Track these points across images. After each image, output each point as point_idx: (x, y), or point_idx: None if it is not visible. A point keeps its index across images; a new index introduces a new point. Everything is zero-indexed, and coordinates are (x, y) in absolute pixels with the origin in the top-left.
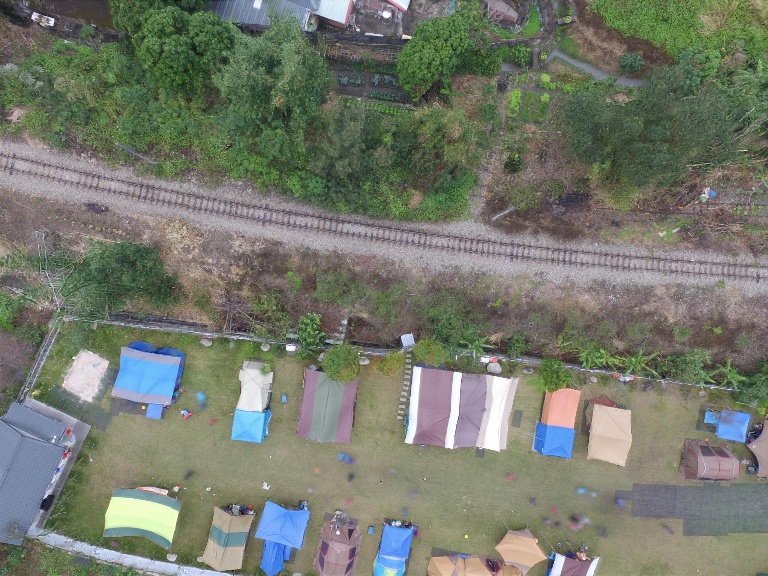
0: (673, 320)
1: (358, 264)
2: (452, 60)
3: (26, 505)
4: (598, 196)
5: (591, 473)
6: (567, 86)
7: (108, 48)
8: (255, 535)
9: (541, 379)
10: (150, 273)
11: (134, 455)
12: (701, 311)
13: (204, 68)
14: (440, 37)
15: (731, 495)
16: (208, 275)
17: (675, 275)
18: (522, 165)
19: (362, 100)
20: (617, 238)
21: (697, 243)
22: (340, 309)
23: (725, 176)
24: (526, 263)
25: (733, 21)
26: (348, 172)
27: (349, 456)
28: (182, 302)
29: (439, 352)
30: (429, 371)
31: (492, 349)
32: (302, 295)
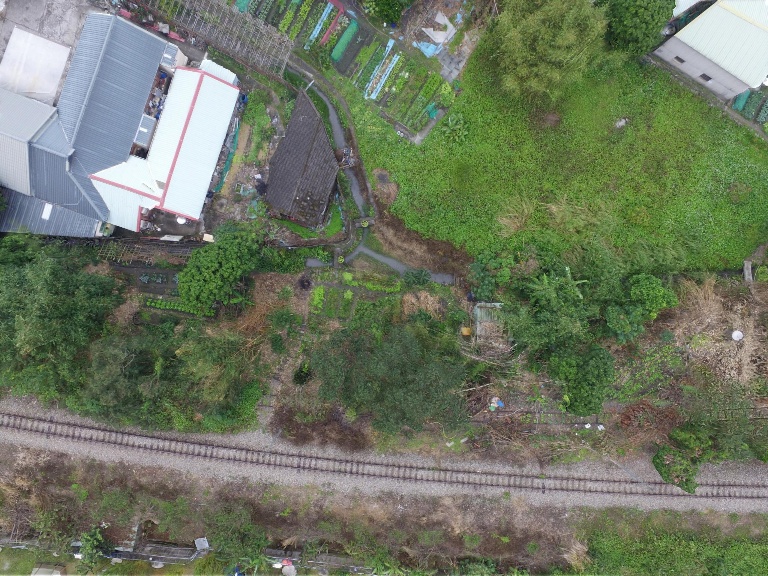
0: (460, 530)
1: (144, 475)
2: (223, 289)
3: None
4: None
5: None
6: (369, 284)
7: None
8: None
9: None
10: None
11: None
12: (489, 520)
13: None
14: (209, 268)
15: None
16: None
17: (461, 486)
18: (313, 374)
19: (163, 298)
20: (405, 448)
21: (484, 454)
22: (130, 516)
23: None
24: (313, 474)
25: (532, 223)
26: None
27: None
28: None
29: None
30: None
31: (292, 547)
32: (91, 503)
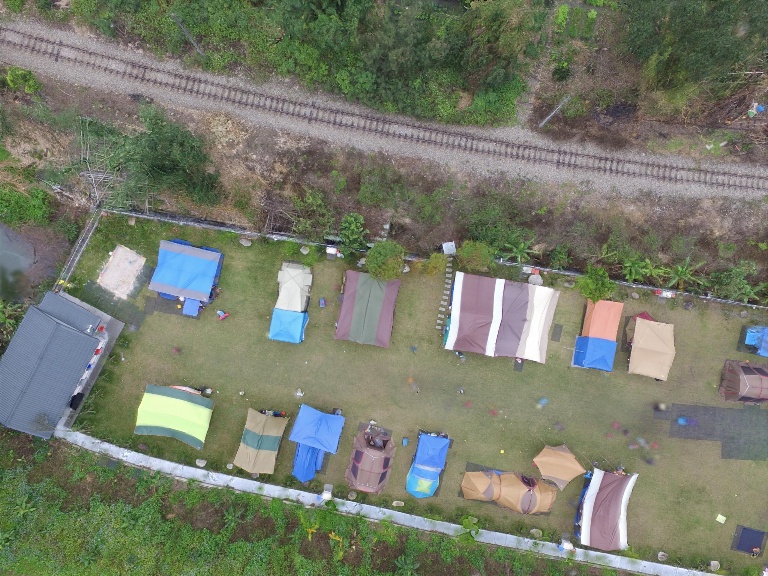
0: (719, 234)
1: (403, 166)
2: None
3: (57, 397)
4: (646, 107)
5: (630, 391)
6: (614, 3)
7: None
8: (290, 438)
9: (582, 293)
10: (197, 157)
11: (167, 356)
12: (747, 226)
13: None
14: None
15: None
16: (250, 173)
17: (722, 188)
18: (570, 74)
19: None
20: (664, 150)
21: (744, 157)
22: (383, 213)
23: None
24: (572, 171)
25: None
26: (399, 67)
27: (386, 365)
28: (221, 203)
29: (486, 249)
30: (471, 277)
31: (533, 263)
32: (345, 197)
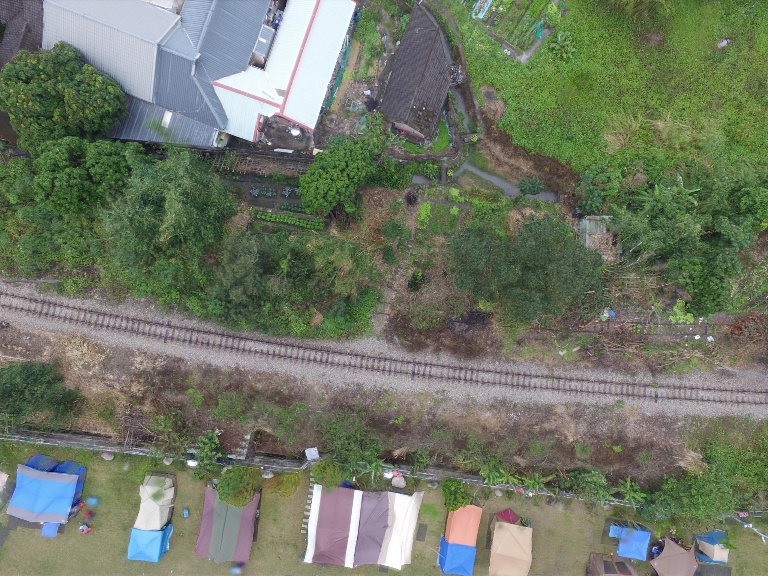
0: (573, 439)
1: (260, 381)
2: (349, 189)
3: None
4: (500, 314)
5: None
6: (475, 200)
7: (16, 163)
8: None
9: None
10: (41, 399)
11: (31, 570)
12: (601, 429)
13: (101, 195)
14: (336, 167)
15: None
16: (110, 389)
17: (575, 394)
18: (426, 283)
19: (273, 212)
20: (518, 356)
21: (596, 362)
22: (243, 424)
23: (625, 295)
24: (427, 381)
25: (636, 140)
26: (246, 296)
27: (252, 571)
28: (86, 413)
29: (333, 478)
30: (330, 489)
31: (399, 461)
32: (205, 410)
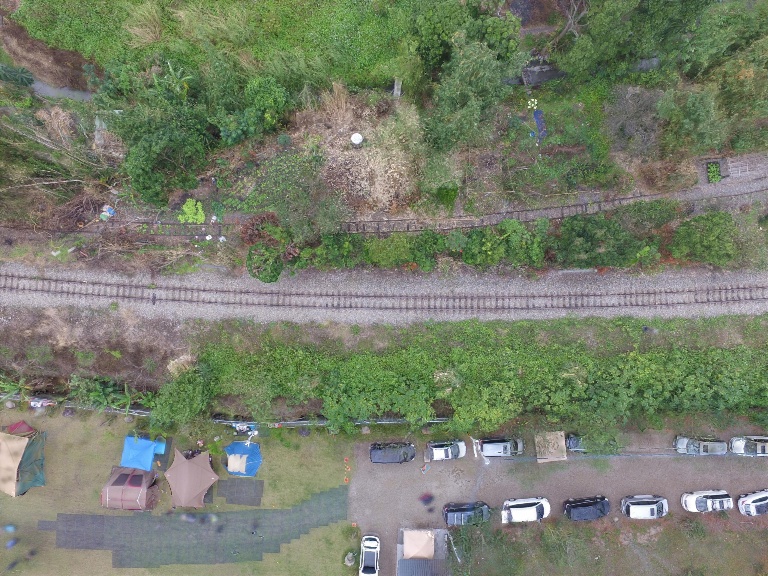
0: (67, 343)
1: None
2: None
3: None
4: None
5: (11, 503)
6: None
7: None
8: None
9: None
10: None
11: None
12: (98, 334)
13: None
14: None
15: (163, 525)
16: None
17: (66, 296)
18: None
19: None
20: (8, 257)
21: (91, 263)
22: None
23: None
24: None
25: (166, 33)
26: None
27: None
28: None
29: None
30: None
31: None
32: None
